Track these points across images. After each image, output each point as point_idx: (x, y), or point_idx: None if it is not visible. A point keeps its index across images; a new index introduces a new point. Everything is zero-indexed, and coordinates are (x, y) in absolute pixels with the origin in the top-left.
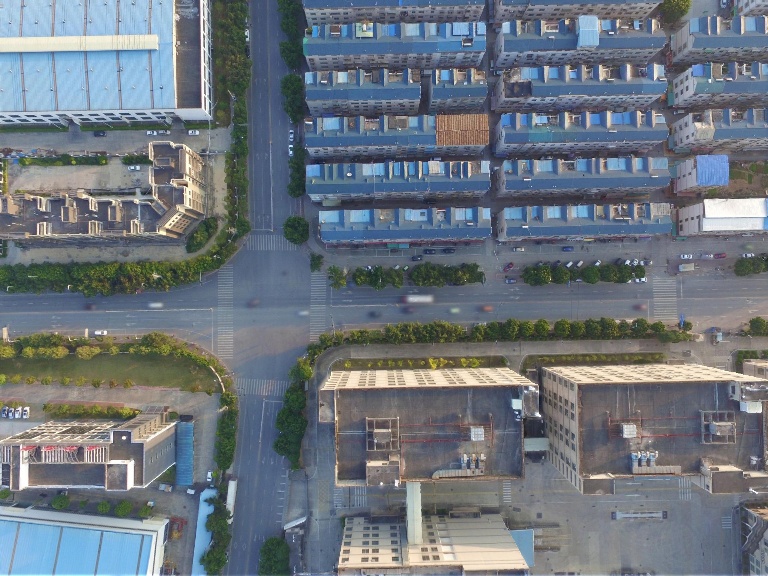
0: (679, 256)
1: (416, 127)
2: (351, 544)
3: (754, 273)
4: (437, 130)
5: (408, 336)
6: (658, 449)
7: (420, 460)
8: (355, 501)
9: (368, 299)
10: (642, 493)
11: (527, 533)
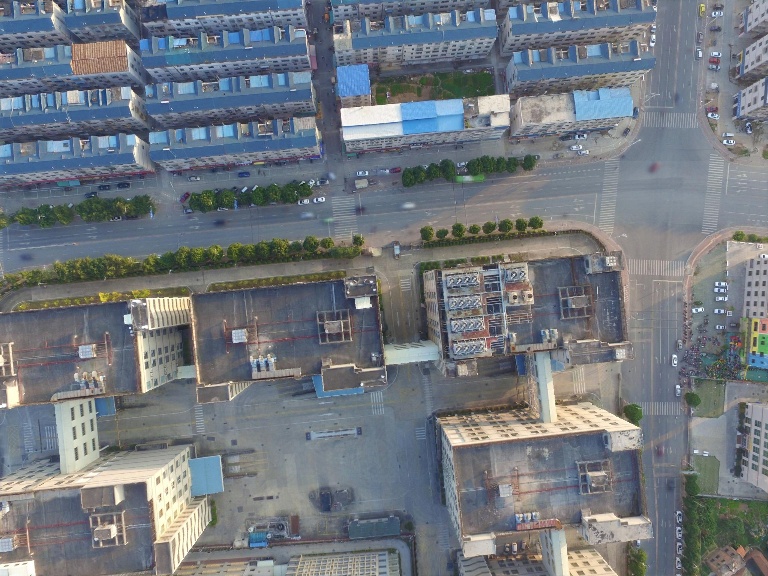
0: (355, 174)
1: (52, 58)
2: (3, 480)
3: (421, 183)
4: (73, 59)
5: (75, 271)
6: (278, 353)
7: (39, 384)
8: (47, 444)
9: (46, 240)
10: (335, 411)
11: (214, 459)
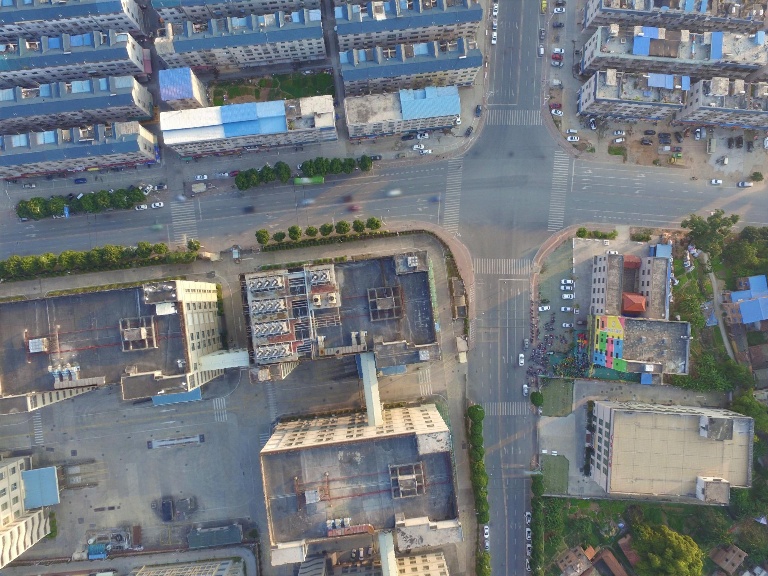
0: (194, 178)
1: None
2: None
3: (256, 186)
4: None
5: None
6: (82, 362)
7: None
8: None
9: None
10: (177, 419)
11: (49, 471)
